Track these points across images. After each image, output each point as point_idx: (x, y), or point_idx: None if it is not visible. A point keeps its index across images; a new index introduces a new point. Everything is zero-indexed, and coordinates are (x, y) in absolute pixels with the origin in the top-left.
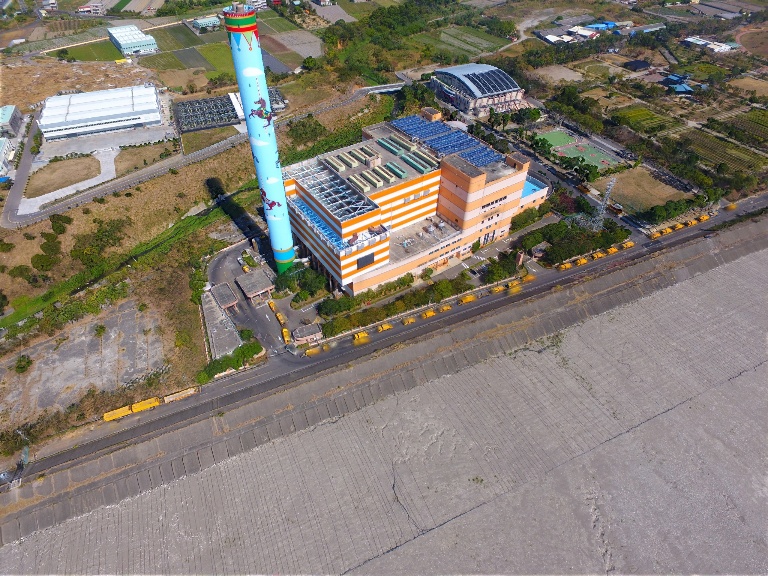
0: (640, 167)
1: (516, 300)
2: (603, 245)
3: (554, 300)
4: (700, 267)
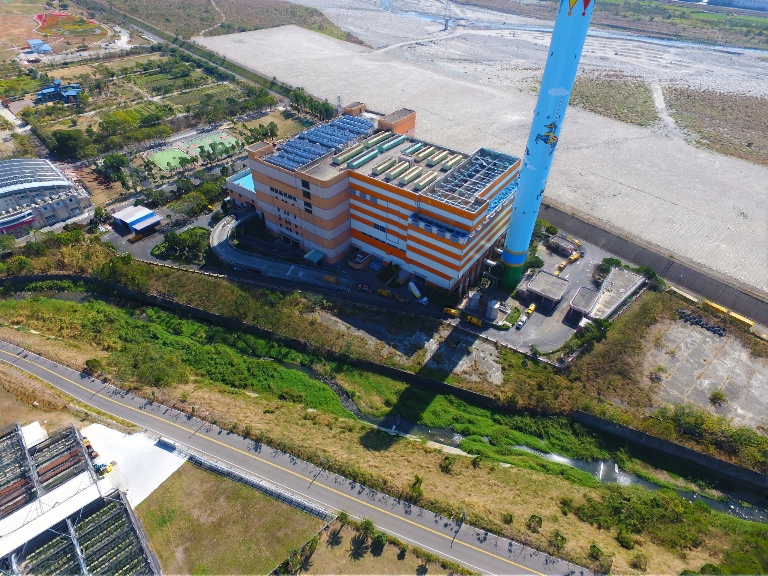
0: (231, 125)
1: None
2: None
3: None
4: None
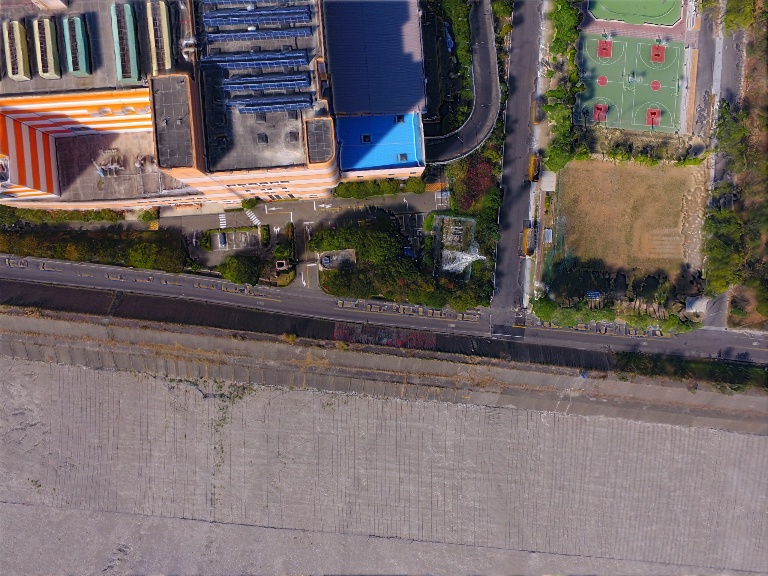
0: (696, 166)
1: (225, 324)
2: (426, 303)
3: (273, 350)
4: (522, 402)
